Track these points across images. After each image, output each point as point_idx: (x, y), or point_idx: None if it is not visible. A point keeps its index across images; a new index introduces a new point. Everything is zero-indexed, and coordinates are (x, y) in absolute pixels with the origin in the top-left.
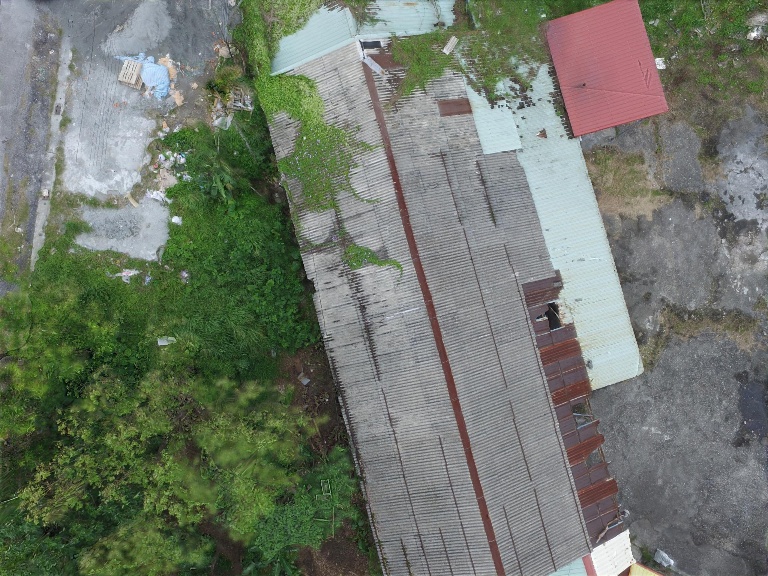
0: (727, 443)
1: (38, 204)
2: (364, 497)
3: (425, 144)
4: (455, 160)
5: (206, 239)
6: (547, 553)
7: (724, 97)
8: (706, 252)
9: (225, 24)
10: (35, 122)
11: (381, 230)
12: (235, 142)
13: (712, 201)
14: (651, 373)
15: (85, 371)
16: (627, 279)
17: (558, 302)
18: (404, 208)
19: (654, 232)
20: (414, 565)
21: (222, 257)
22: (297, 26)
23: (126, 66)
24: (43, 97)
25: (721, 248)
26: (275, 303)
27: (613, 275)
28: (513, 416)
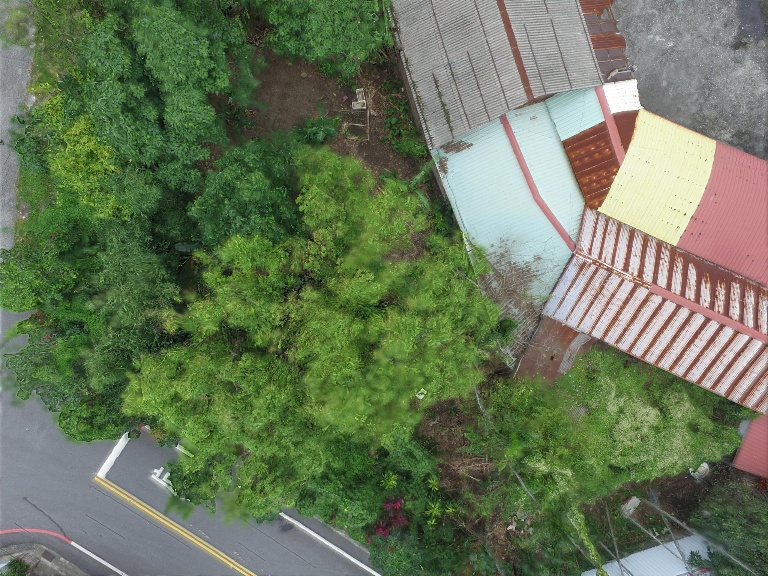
0: (726, 47)
1: None
2: (398, 46)
3: None
4: None
5: None
6: (564, 73)
7: None
8: None
9: None
10: None
11: None
12: None
13: None
14: None
15: None
16: None
17: None
18: None
19: None
20: (445, 94)
21: None
22: None
23: None
24: None
25: None
26: None
27: None
28: None
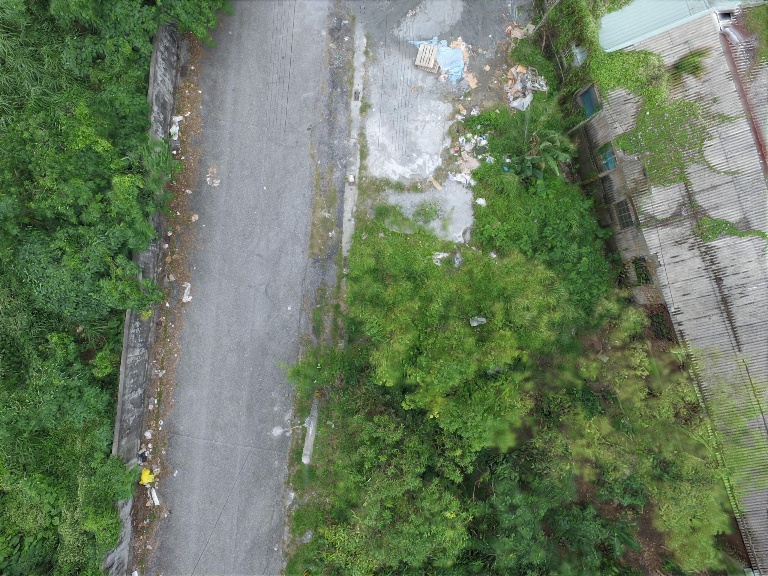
0: None
1: (345, 190)
2: None
3: None
4: None
5: (518, 219)
6: None
7: None
8: None
9: (514, 5)
10: (336, 109)
11: (742, 201)
12: (538, 122)
13: None
14: None
15: (416, 352)
16: None
17: None
18: None
19: None
20: None
21: (536, 236)
22: (624, 2)
23: (422, 50)
24: (342, 84)
25: None
26: (589, 281)
27: None
28: None
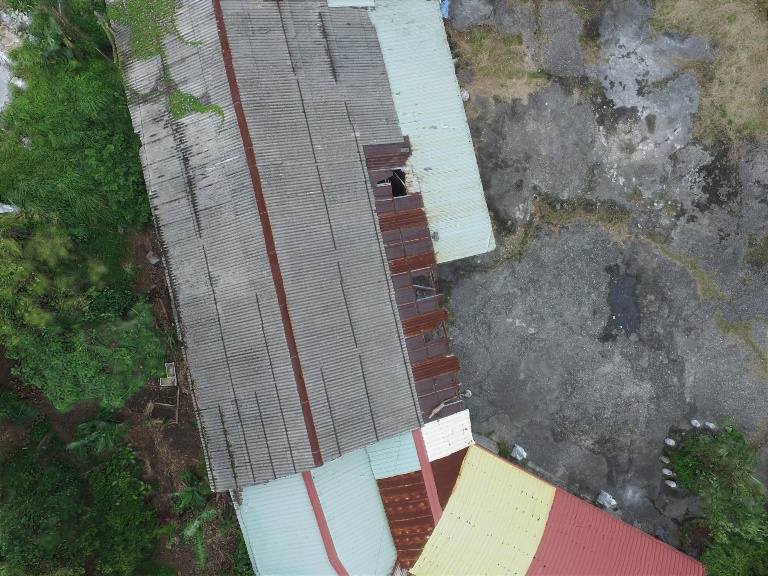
0: (594, 338)
1: None
2: (185, 363)
3: None
4: (293, 8)
5: (43, 99)
6: (369, 422)
7: None
8: (582, 139)
9: None
10: None
11: (204, 74)
12: None
13: (591, 86)
14: (518, 263)
15: None
16: (498, 165)
17: (405, 169)
18: (226, 48)
19: (529, 117)
20: (231, 433)
21: (59, 118)
22: None
23: None
24: None
25: (598, 136)
26: (115, 170)
27: (468, 146)
28: (340, 278)
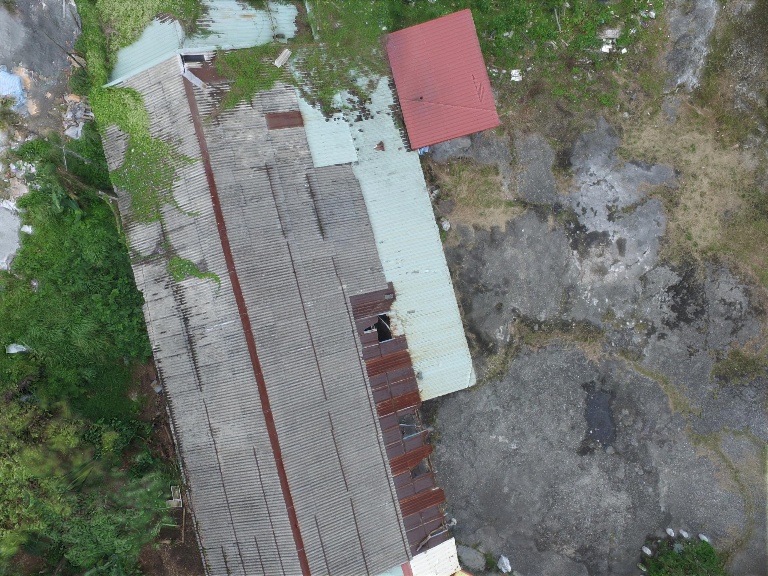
0: (573, 452)
1: None
2: (189, 505)
3: (249, 158)
4: (282, 173)
5: (52, 248)
6: (361, 561)
7: (579, 109)
8: (557, 263)
9: (79, 33)
10: None
11: (201, 243)
12: (84, 152)
13: (565, 213)
14: (500, 383)
15: None
16: (479, 290)
17: (390, 314)
18: (221, 222)
19: (507, 243)
20: (233, 572)
21: (67, 266)
22: (132, 38)
23: None
24: None
25: (572, 259)
26: (120, 312)
27: (448, 287)
28: (331, 427)
